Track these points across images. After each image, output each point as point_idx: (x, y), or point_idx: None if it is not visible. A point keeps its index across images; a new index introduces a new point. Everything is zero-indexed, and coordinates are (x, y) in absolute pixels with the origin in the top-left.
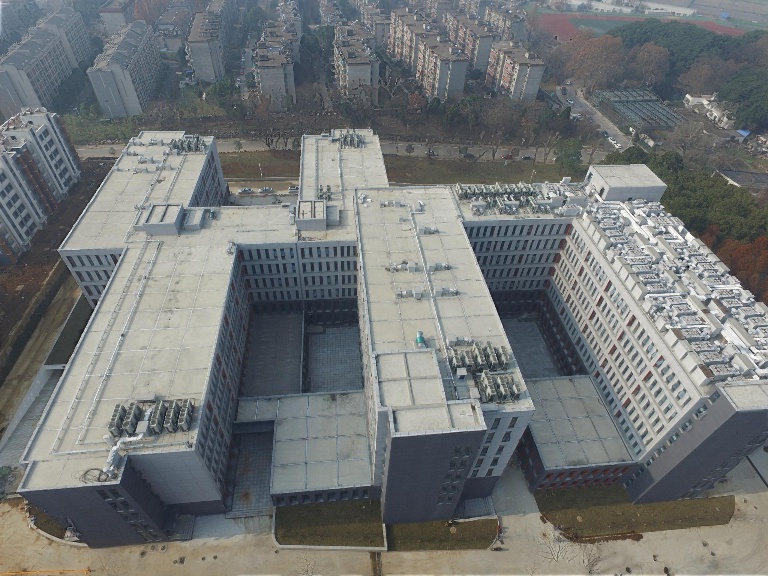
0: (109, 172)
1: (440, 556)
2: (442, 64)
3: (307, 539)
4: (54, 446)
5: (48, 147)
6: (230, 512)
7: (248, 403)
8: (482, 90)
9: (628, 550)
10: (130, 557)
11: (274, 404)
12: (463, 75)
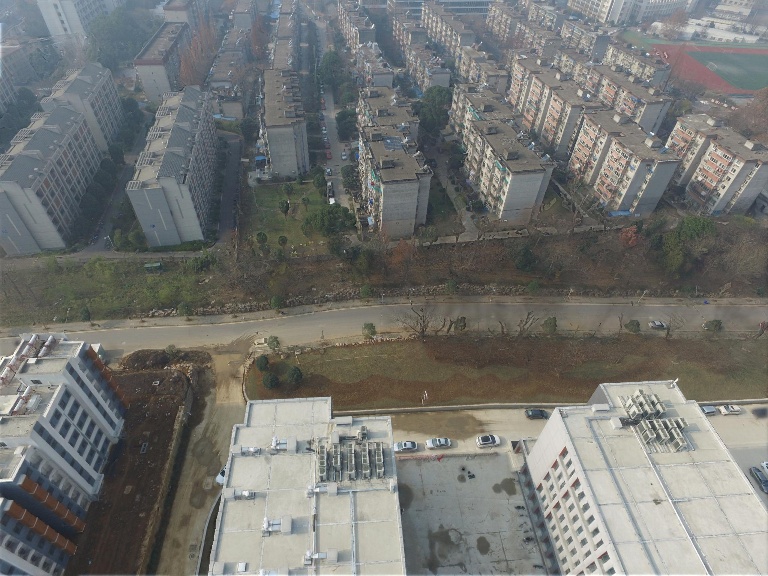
0: None
1: None
2: (641, 166)
3: None
4: None
5: (69, 422)
6: None
7: None
8: None
9: None
10: None
11: None
12: (666, 179)
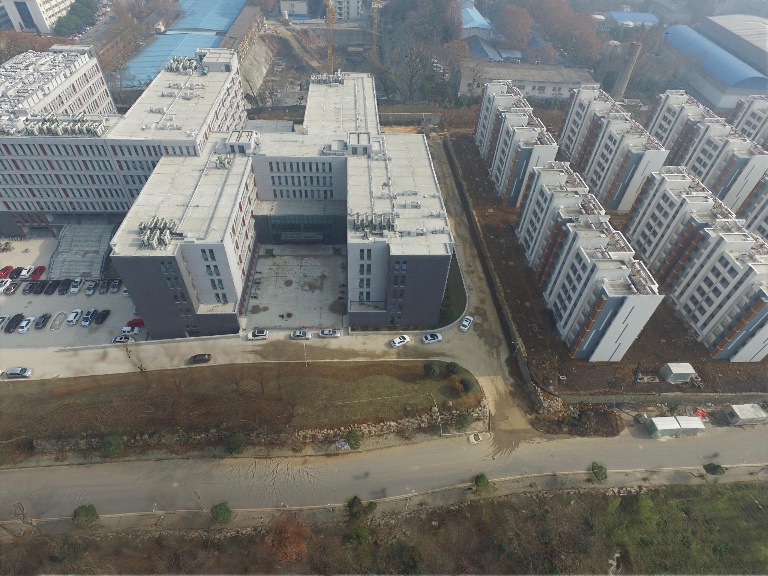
0: None
1: None
2: None
3: None
4: None
5: None
6: None
7: None
8: None
9: None
10: None
11: None
12: None
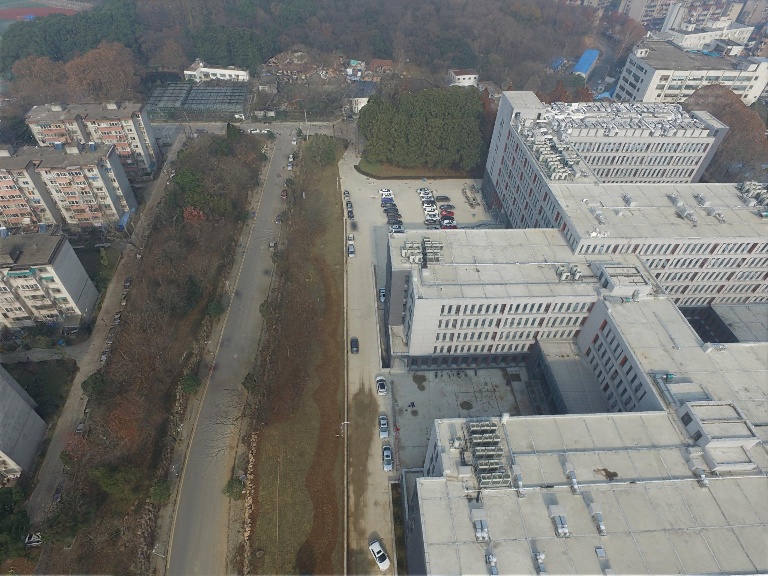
0: None
1: None
2: (99, 170)
3: None
4: None
5: None
6: None
7: None
8: None
9: None
10: None
11: None
12: (119, 167)
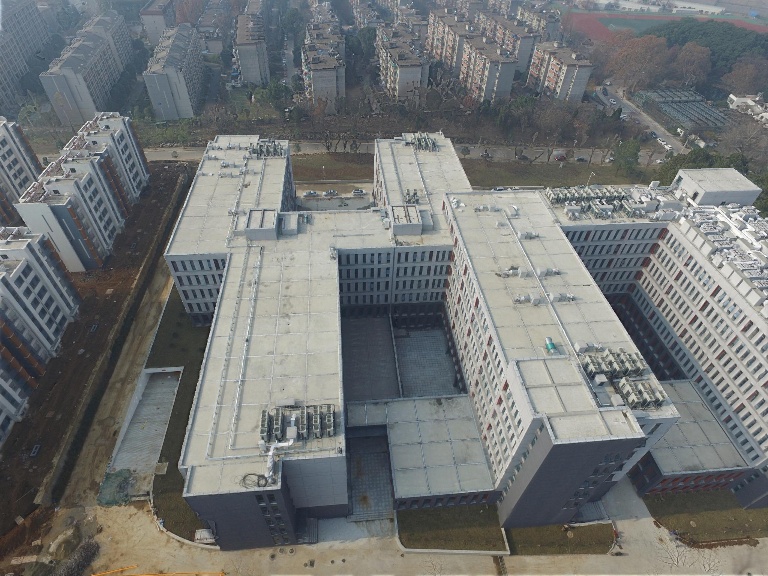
0: (195, 177)
1: (562, 560)
2: (491, 65)
3: (431, 543)
4: (208, 451)
5: (123, 151)
6: (351, 516)
7: (356, 407)
8: (524, 91)
9: (746, 555)
10: (261, 560)
11: (382, 408)
12: (511, 76)
